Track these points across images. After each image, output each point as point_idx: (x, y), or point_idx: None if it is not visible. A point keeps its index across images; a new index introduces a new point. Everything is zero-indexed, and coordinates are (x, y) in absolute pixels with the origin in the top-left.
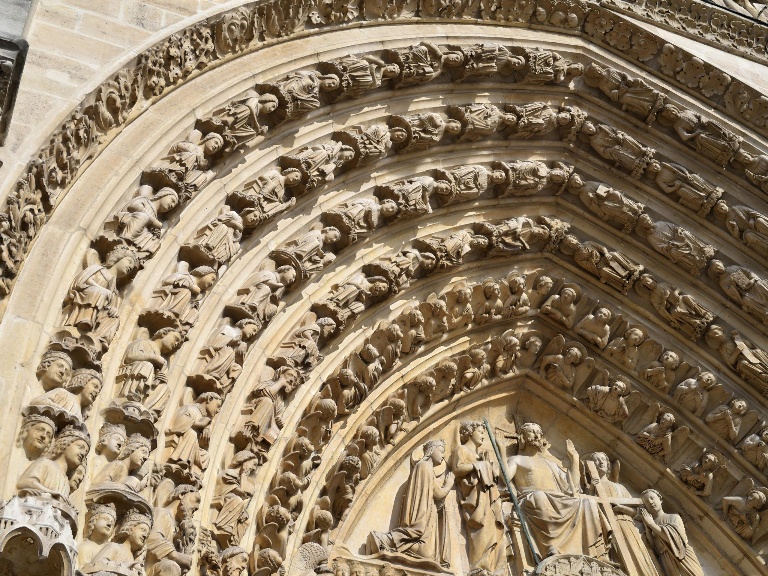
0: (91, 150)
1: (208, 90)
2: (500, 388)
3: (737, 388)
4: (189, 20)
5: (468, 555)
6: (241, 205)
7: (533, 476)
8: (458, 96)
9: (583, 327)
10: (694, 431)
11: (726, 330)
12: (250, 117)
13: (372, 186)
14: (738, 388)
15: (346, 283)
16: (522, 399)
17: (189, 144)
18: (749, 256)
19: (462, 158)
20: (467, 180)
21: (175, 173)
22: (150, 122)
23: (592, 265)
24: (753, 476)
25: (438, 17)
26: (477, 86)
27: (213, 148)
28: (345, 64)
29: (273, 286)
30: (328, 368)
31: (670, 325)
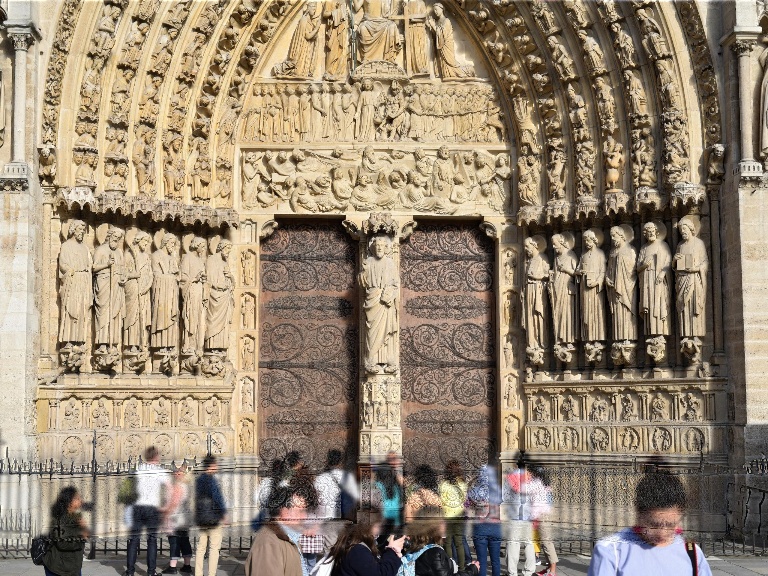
0: (79, 8)
1: None
2: None
3: None
4: None
5: (325, 64)
6: None
7: (370, 7)
8: None
9: None
10: None
11: None
12: None
13: None
14: None
15: None
16: None
17: None
18: None
19: None
20: None
21: None
22: None
23: None
24: None
25: None
26: None
27: None
28: None
29: (184, 3)
30: (233, 6)
31: None
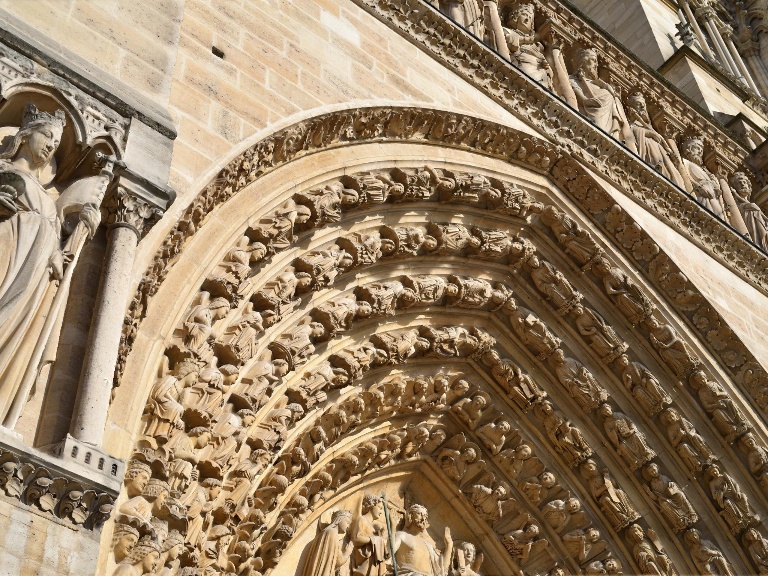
0: (175, 259)
1: (261, 198)
2: (401, 467)
3: (595, 517)
4: (261, 133)
5: None
6: (262, 303)
7: (413, 555)
8: (439, 214)
9: (484, 432)
10: (551, 544)
11: (599, 465)
12: (289, 229)
13: (355, 286)
14: (596, 517)
15: (317, 372)
16: (415, 479)
17: (241, 252)
18: (634, 407)
19: (428, 268)
20: (429, 291)
21: (232, 286)
22: (216, 228)
23: (505, 381)
24: None
25: (441, 141)
26: (456, 208)
27: (258, 258)
28: (365, 182)
29: (270, 379)
30: (285, 444)
31: (555, 449)
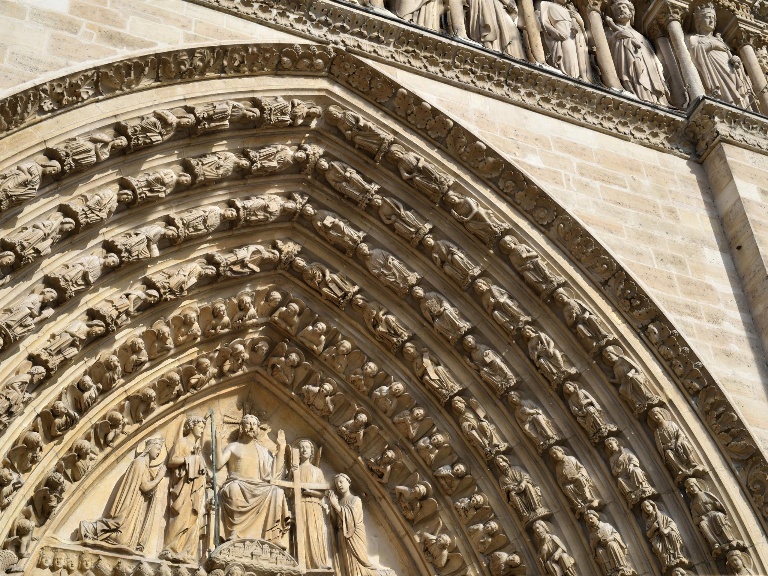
0: None
1: None
2: (231, 383)
3: (422, 395)
4: None
5: (165, 536)
6: None
7: (241, 464)
8: (194, 148)
9: (303, 336)
10: (384, 428)
11: (420, 346)
12: None
13: (100, 241)
14: (423, 395)
15: (64, 331)
16: (253, 389)
17: None
18: (448, 283)
19: (197, 201)
20: (196, 224)
21: None
22: None
23: (315, 285)
24: (423, 470)
25: (180, 79)
26: (214, 137)
27: None
28: (69, 149)
29: None
30: (44, 401)
31: (375, 338)
